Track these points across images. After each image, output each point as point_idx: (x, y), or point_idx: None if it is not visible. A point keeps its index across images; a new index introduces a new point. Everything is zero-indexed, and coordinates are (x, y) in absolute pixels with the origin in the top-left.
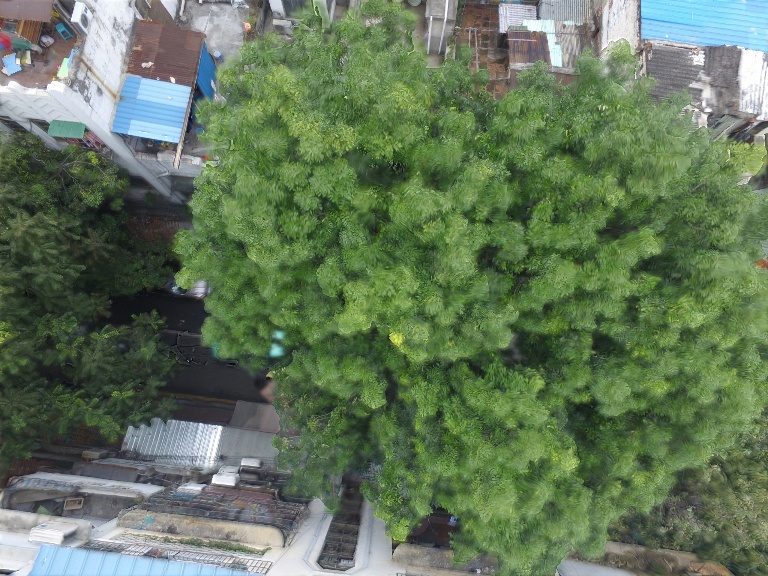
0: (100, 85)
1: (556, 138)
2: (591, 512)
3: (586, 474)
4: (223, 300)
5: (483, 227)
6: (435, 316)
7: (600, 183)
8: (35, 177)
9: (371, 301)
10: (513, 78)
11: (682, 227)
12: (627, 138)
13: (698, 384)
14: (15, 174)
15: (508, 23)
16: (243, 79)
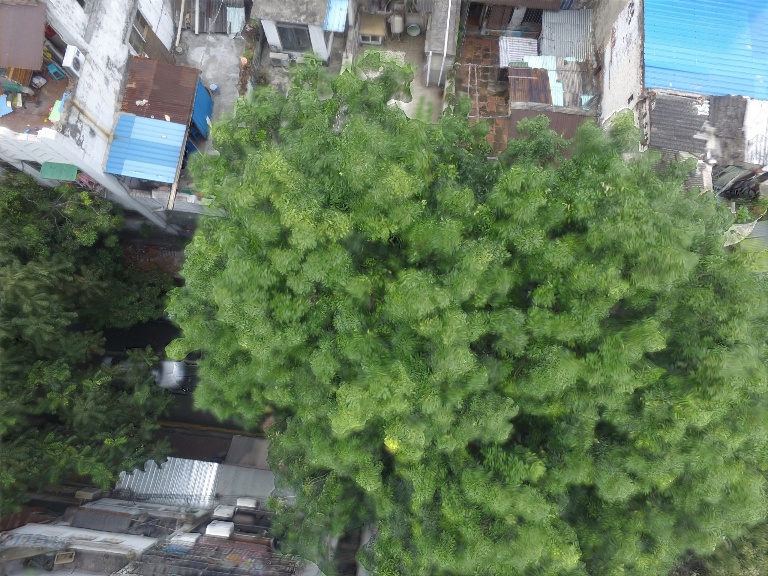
0: (93, 126)
1: (558, 215)
2: None
3: (588, 552)
4: (215, 366)
5: (482, 314)
6: (432, 414)
7: (604, 276)
8: (27, 217)
9: (365, 402)
10: (513, 118)
11: (688, 315)
12: (632, 232)
13: (705, 480)
14: (6, 215)
15: (508, 57)
16: (237, 137)
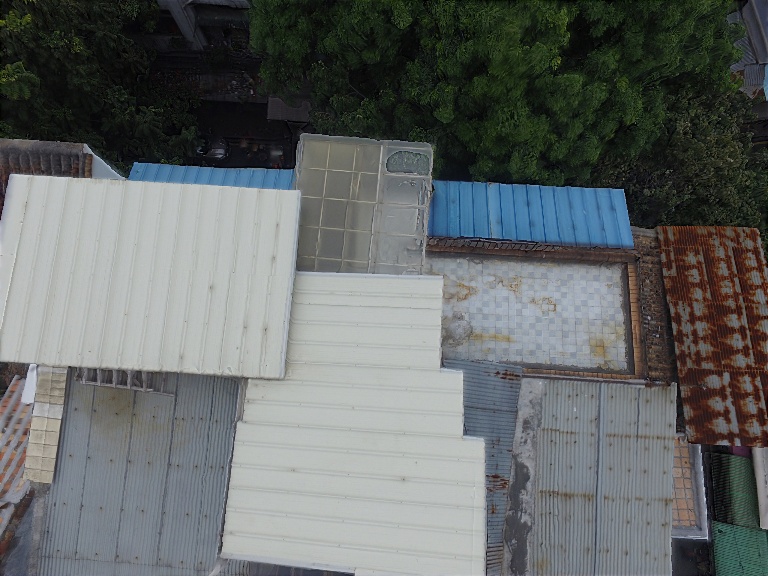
0: None
1: None
2: (582, 95)
3: None
4: None
5: None
6: None
7: None
8: None
9: None
10: None
11: None
12: None
13: None
14: None
15: None
16: None
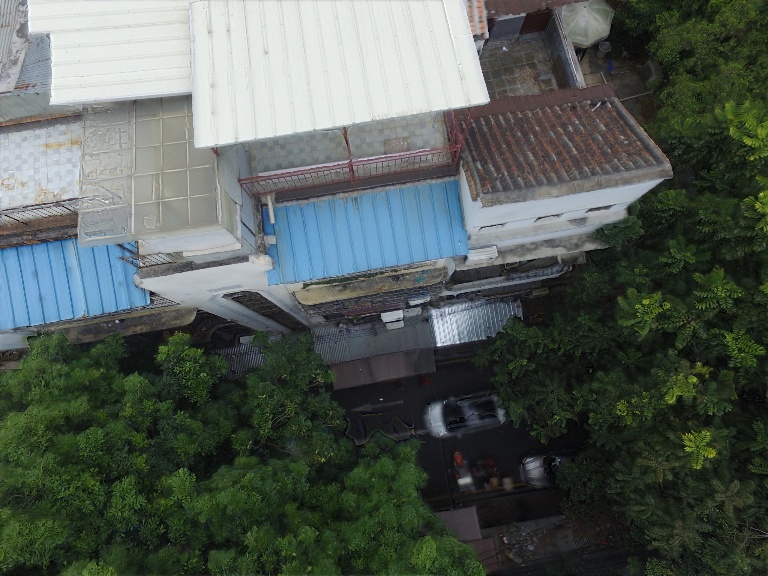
0: None
1: None
2: None
3: None
4: (394, 527)
5: None
6: None
7: None
8: None
9: None
10: None
11: None
12: None
13: None
14: None
15: None
16: None
